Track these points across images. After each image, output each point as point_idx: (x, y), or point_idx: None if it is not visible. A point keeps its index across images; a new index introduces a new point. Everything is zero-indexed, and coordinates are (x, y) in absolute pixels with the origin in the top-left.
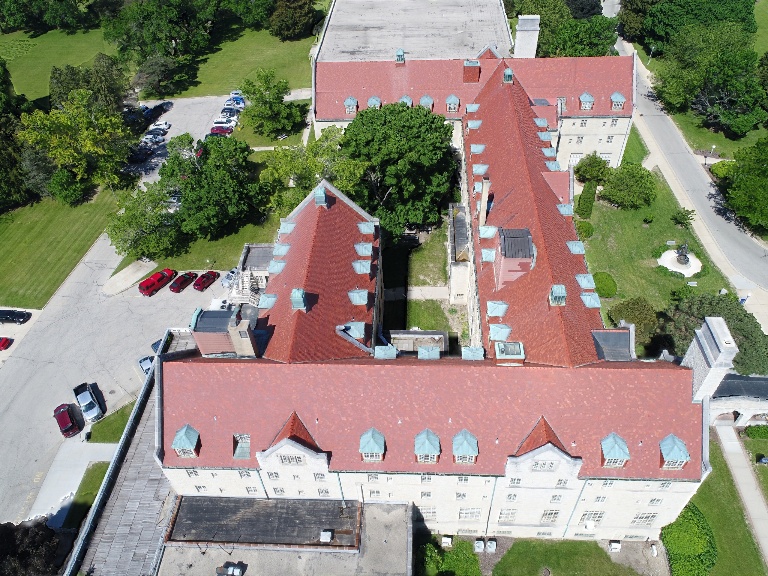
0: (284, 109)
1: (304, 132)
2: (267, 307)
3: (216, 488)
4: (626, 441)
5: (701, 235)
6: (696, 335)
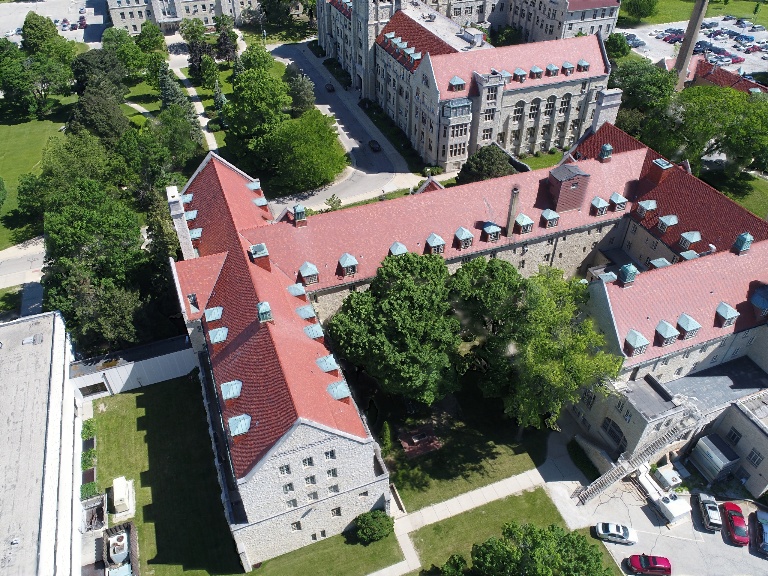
0: None
1: None
2: (733, 308)
3: None
4: None
5: (341, 204)
6: (602, 107)
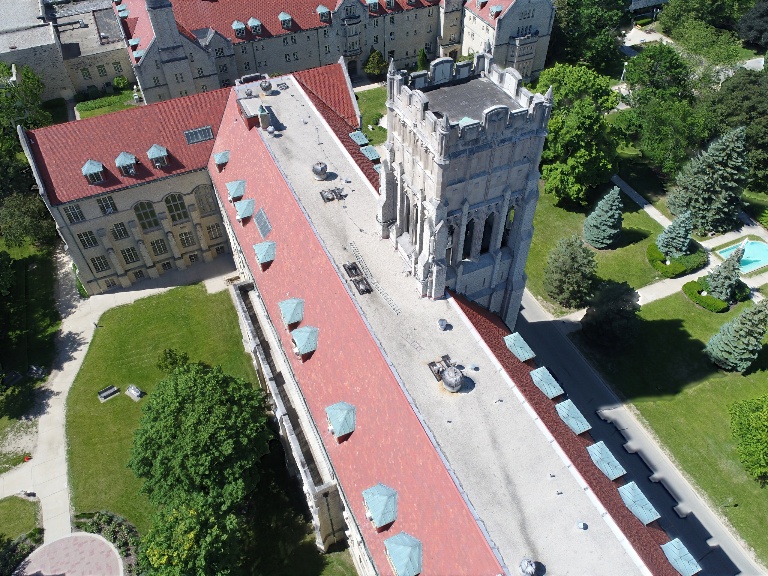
0: None
1: None
2: None
3: None
4: None
5: None
6: None
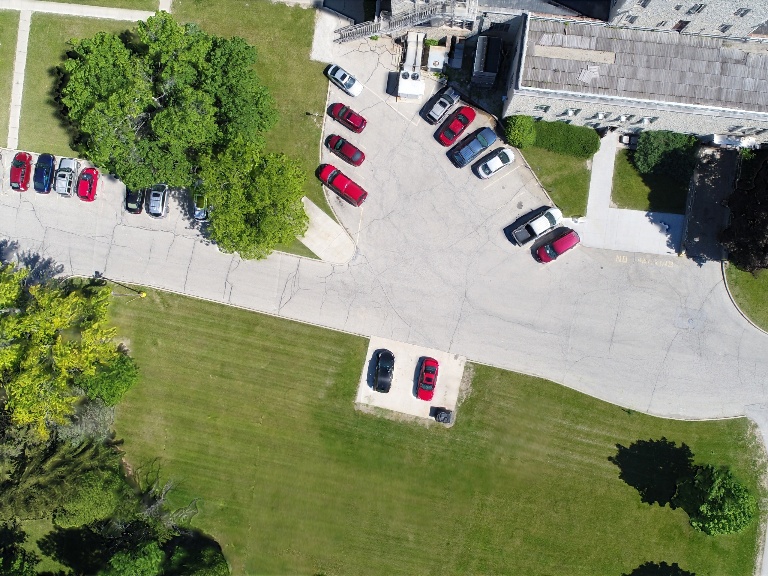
0: None
1: None
2: None
3: None
4: None
5: None
6: None
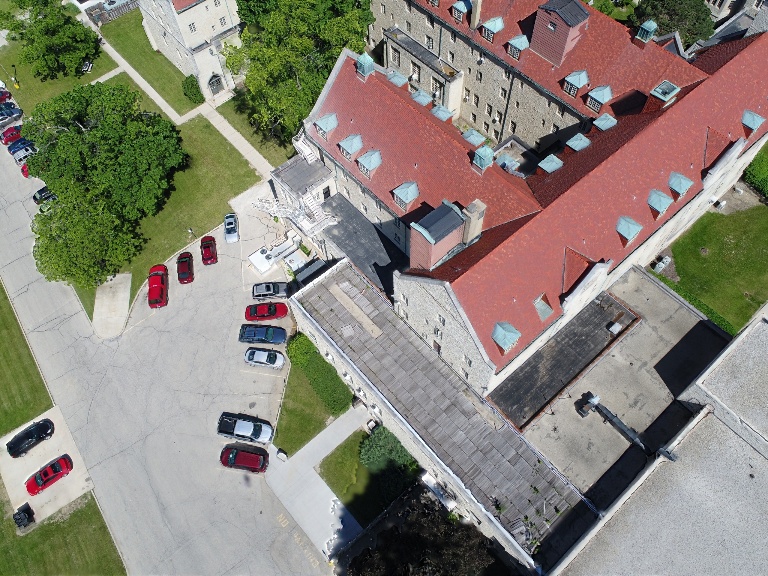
0: (74, 29)
1: (105, 50)
2: (414, 197)
3: (516, 364)
4: (752, 111)
5: None
6: (766, 1)
